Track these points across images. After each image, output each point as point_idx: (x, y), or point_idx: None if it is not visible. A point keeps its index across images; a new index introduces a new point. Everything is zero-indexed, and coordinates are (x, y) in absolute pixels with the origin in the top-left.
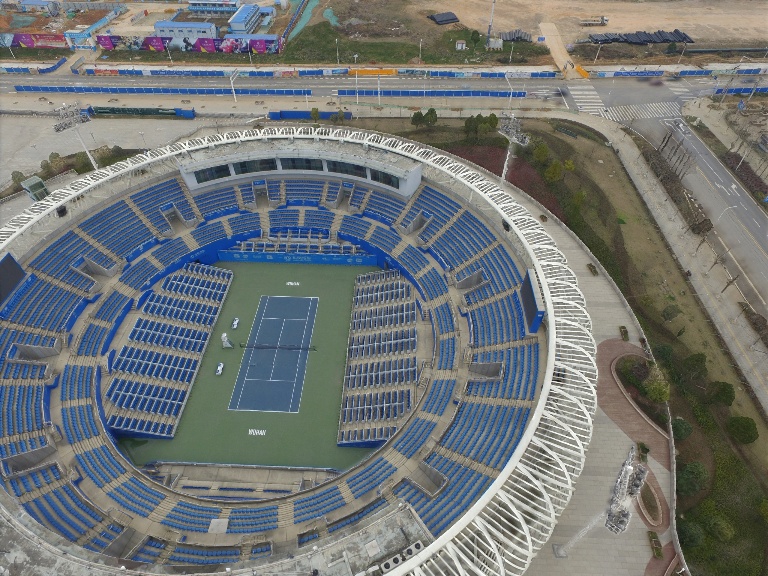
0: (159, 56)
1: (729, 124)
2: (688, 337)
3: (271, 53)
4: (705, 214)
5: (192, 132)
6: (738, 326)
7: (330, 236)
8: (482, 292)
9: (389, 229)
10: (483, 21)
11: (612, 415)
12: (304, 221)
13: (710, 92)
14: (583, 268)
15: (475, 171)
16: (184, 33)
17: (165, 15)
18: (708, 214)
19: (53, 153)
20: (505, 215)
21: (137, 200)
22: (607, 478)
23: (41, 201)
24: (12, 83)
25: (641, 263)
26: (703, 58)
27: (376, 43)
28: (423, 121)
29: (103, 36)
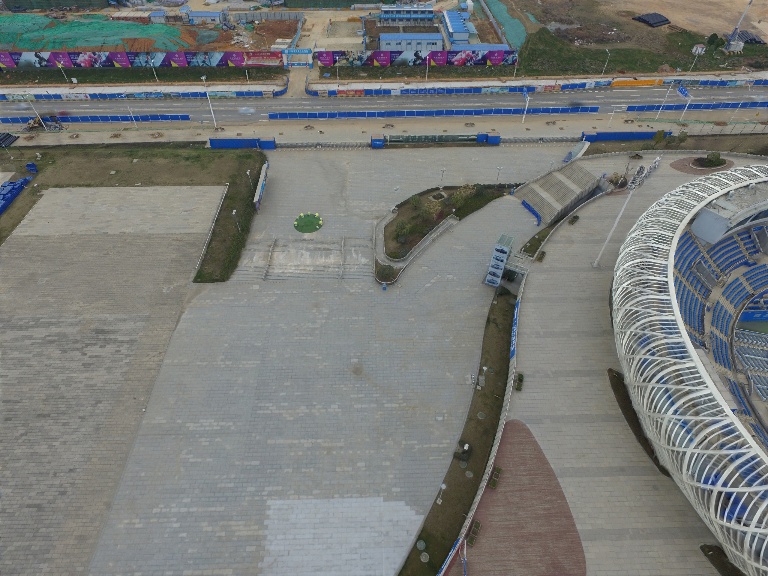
0: (387, 72)
1: None
2: None
3: (507, 65)
4: None
5: (564, 165)
6: None
7: None
8: None
9: None
10: (694, 22)
11: None
12: None
13: None
14: None
15: None
16: (412, 46)
17: (350, 24)
18: None
19: (416, 196)
20: None
21: None
22: None
23: (645, 276)
24: (252, 109)
25: None
26: None
27: (610, 50)
28: None
29: (325, 52)
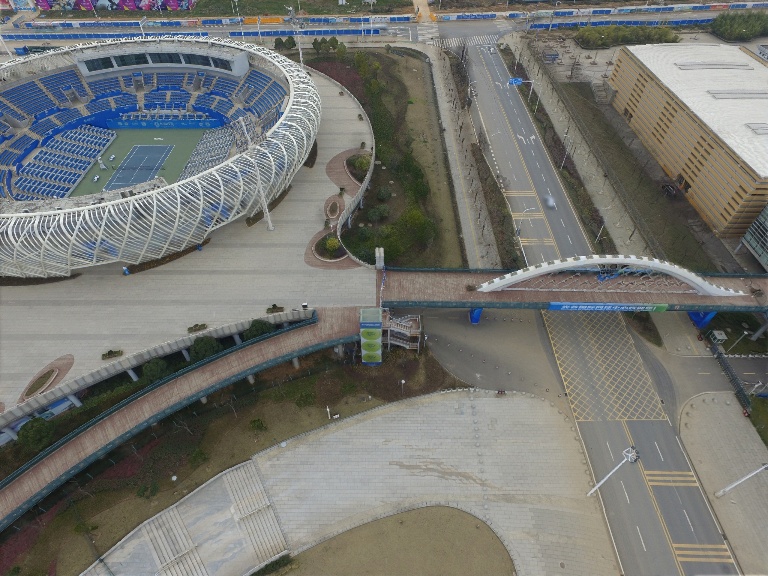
0: (89, 14)
1: (528, 47)
2: (424, 159)
3: (183, 10)
4: (477, 99)
5: None
6: (463, 155)
7: (187, 108)
8: (272, 124)
9: (227, 100)
10: None
11: (333, 179)
12: (170, 100)
13: (525, 27)
14: (355, 117)
15: (306, 71)
16: None
17: None
18: (479, 99)
19: None
20: (286, 73)
21: (44, 82)
22: (315, 203)
23: None
24: None
25: (412, 124)
26: (535, 6)
27: (272, 1)
28: (282, 45)
29: None
